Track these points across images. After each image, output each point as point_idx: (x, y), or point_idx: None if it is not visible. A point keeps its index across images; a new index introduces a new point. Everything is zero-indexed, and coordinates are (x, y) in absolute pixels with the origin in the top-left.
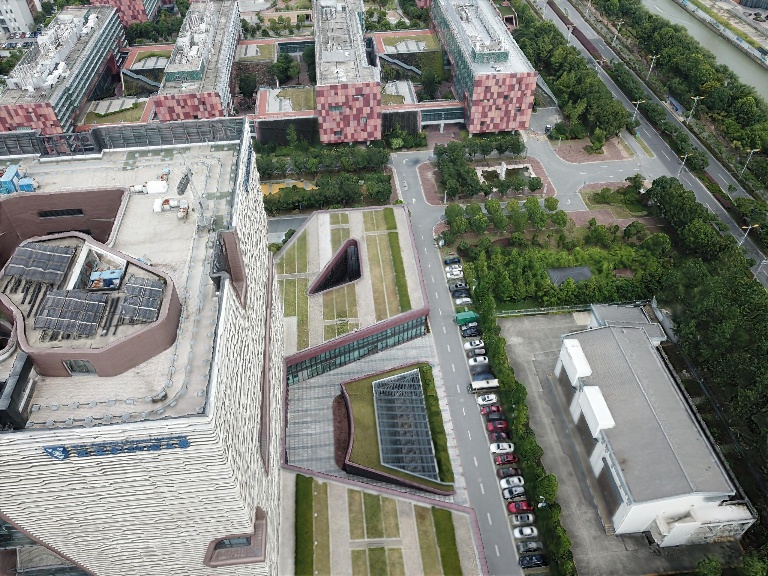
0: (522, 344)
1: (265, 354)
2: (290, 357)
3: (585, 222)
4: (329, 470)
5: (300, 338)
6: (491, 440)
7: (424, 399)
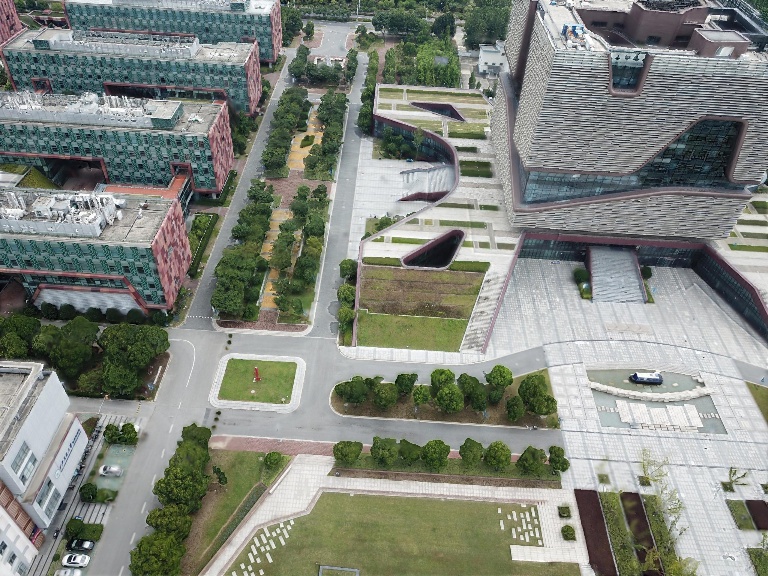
0: None
1: None
2: None
3: (384, 56)
4: None
5: None
6: None
7: None
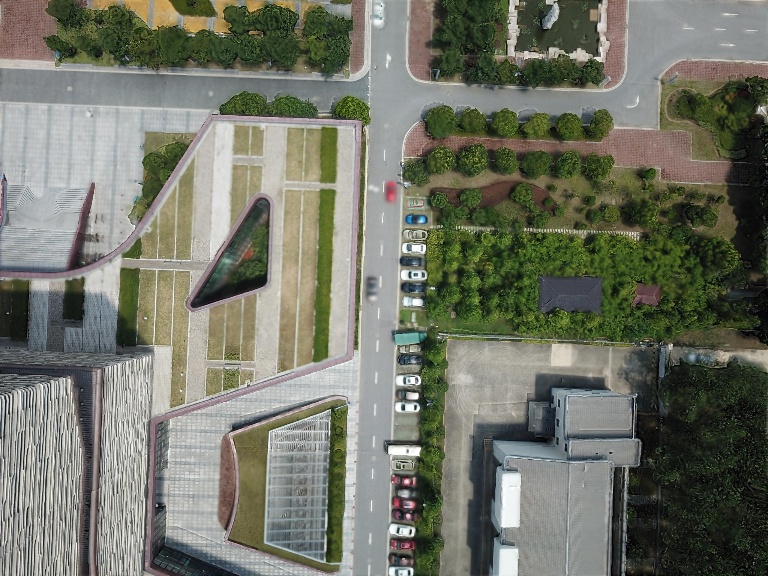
0: (470, 387)
1: (88, 569)
2: (160, 417)
3: (642, 159)
4: (210, 528)
5: (174, 386)
6: (393, 518)
7: (329, 456)
